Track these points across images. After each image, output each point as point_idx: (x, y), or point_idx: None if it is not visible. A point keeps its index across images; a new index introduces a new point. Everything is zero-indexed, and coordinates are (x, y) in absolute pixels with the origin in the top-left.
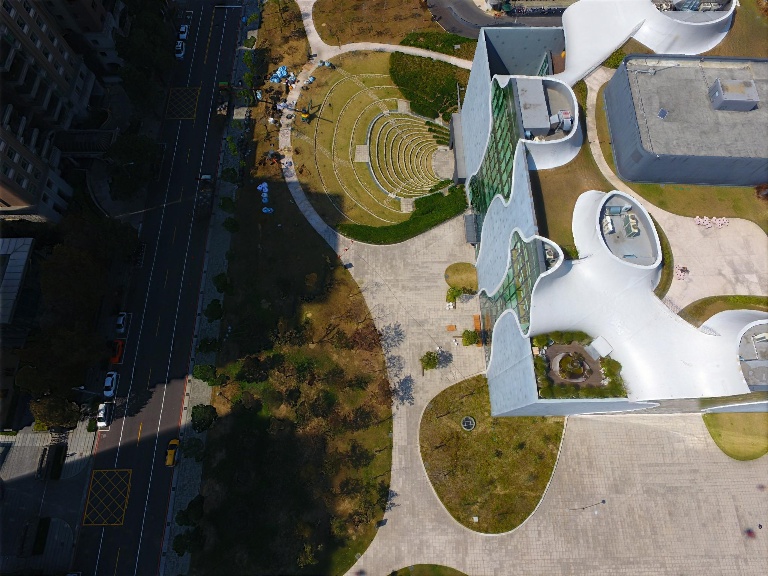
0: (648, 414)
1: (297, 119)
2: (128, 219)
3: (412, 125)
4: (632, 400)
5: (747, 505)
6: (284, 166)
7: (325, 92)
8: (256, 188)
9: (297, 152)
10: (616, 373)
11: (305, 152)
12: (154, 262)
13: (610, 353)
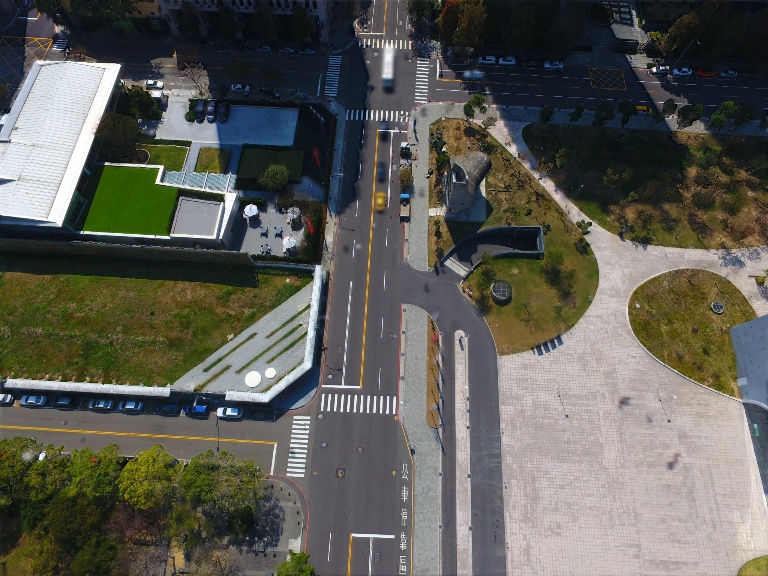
0: (763, 489)
1: None
2: None
3: None
4: None
5: None
6: None
7: None
8: None
9: None
10: None
11: None
12: None
13: None
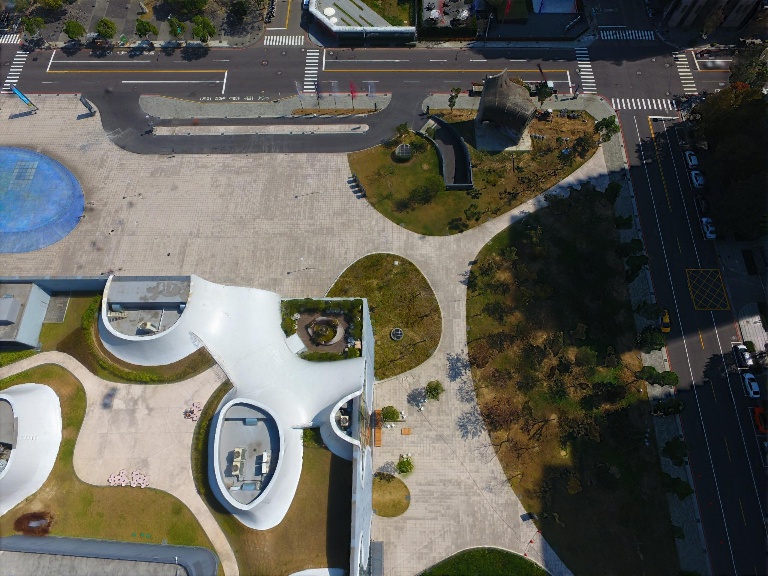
0: None
1: None
2: None
3: None
4: None
5: (172, 269)
6: None
7: None
8: None
9: None
10: (288, 319)
11: None
12: (767, 538)
13: None
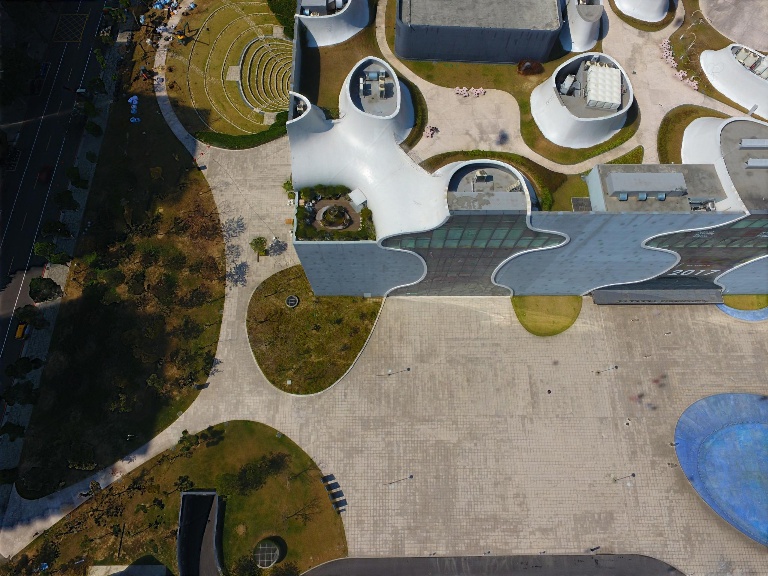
0: (461, 296)
1: (174, 41)
2: (7, 129)
3: (286, 49)
4: (377, 241)
5: (540, 374)
6: (156, 82)
7: (204, 18)
8: (128, 101)
9: (171, 70)
10: (366, 218)
11: (178, 70)
12: (27, 166)
13: (367, 204)
